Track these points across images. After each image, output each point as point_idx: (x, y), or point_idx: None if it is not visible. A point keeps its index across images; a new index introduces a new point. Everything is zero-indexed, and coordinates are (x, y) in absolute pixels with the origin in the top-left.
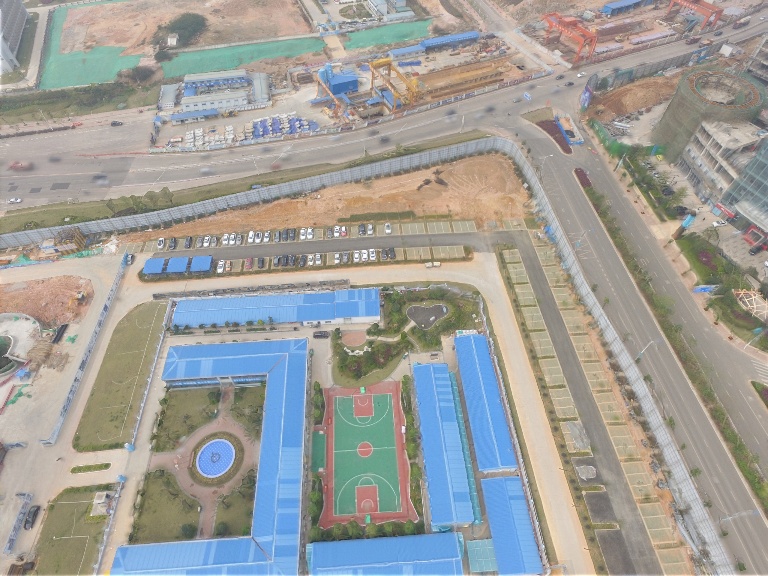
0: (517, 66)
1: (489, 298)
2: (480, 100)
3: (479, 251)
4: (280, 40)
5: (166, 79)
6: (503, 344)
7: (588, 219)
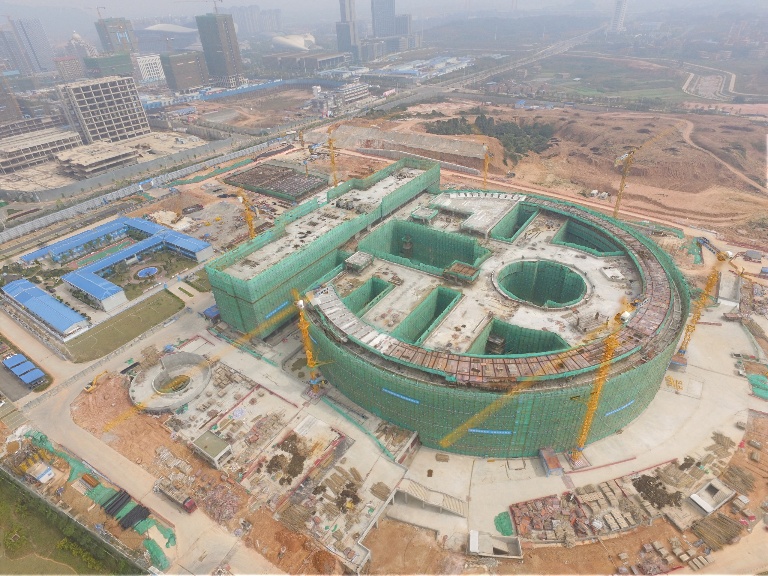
0: None
1: None
2: None
3: None
4: None
5: None
6: None
7: None
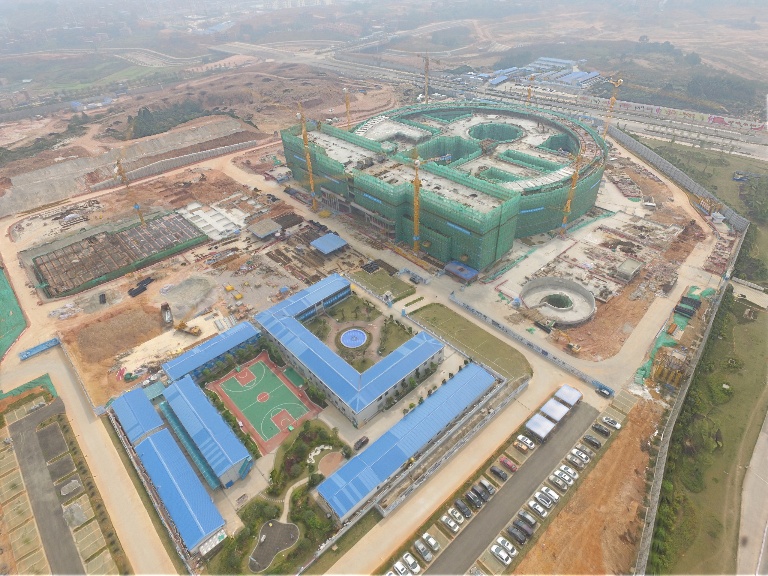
0: None
1: None
2: None
3: None
4: None
5: None
6: (168, 568)
7: None
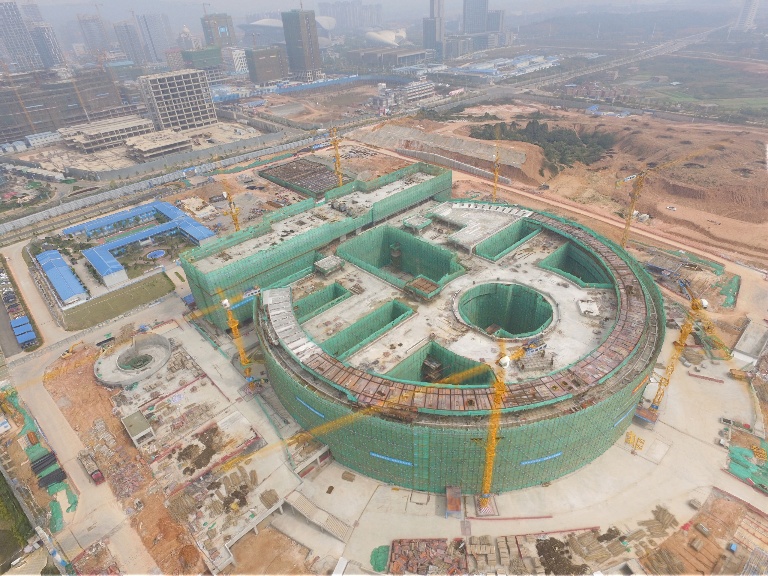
0: None
1: None
2: None
3: None
4: None
5: None
6: None
7: None
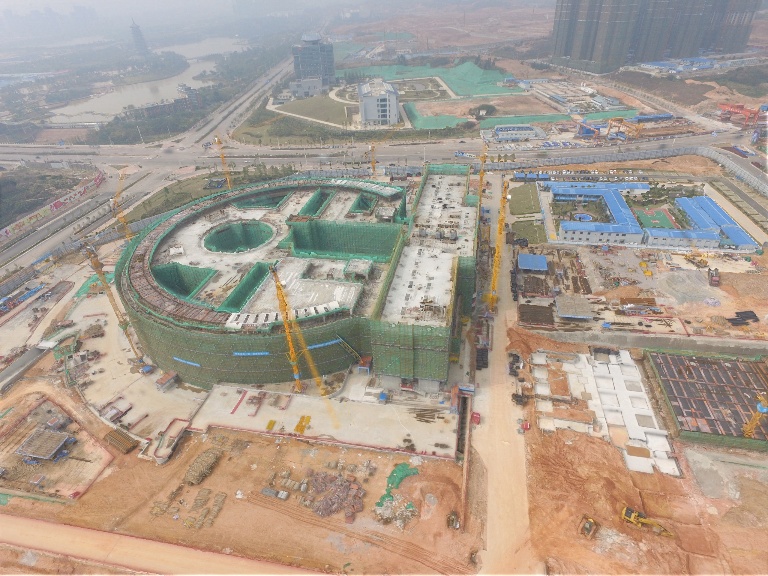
0: (702, 129)
1: (708, 193)
2: (680, 140)
3: (697, 181)
4: (544, 115)
5: (481, 129)
6: (720, 204)
7: (763, 177)
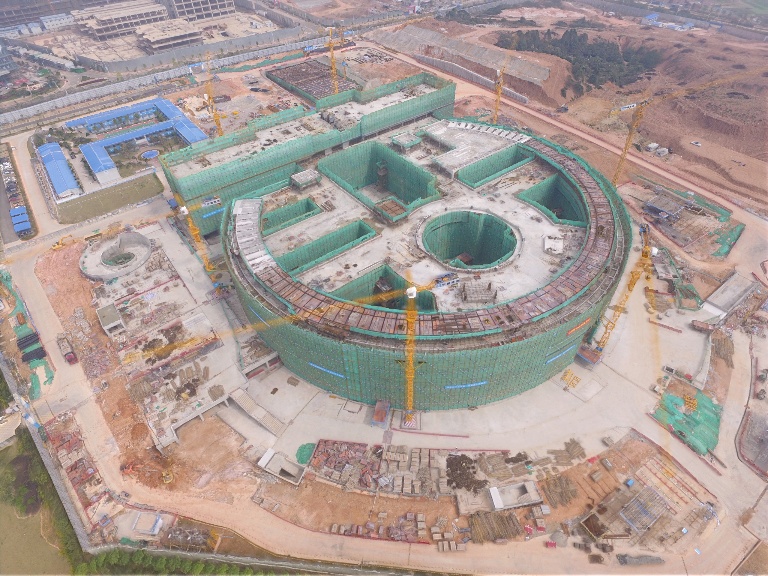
0: None
1: None
2: None
3: None
4: None
5: None
6: None
7: None
